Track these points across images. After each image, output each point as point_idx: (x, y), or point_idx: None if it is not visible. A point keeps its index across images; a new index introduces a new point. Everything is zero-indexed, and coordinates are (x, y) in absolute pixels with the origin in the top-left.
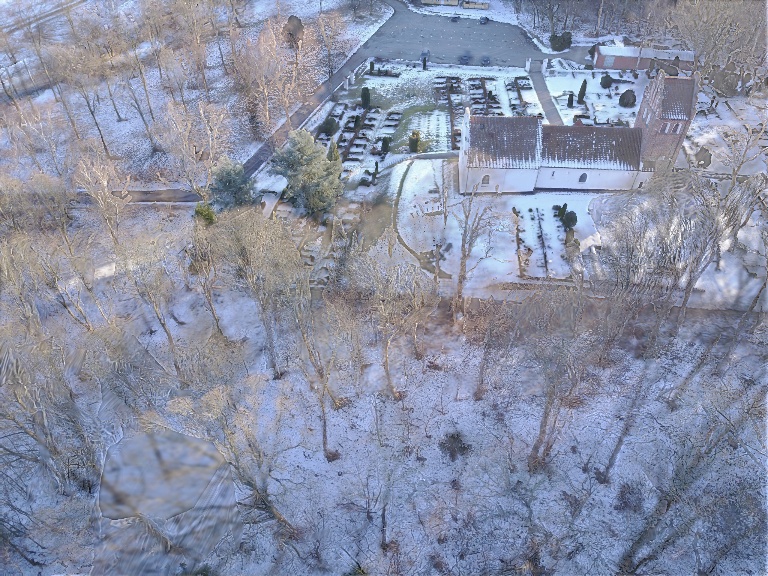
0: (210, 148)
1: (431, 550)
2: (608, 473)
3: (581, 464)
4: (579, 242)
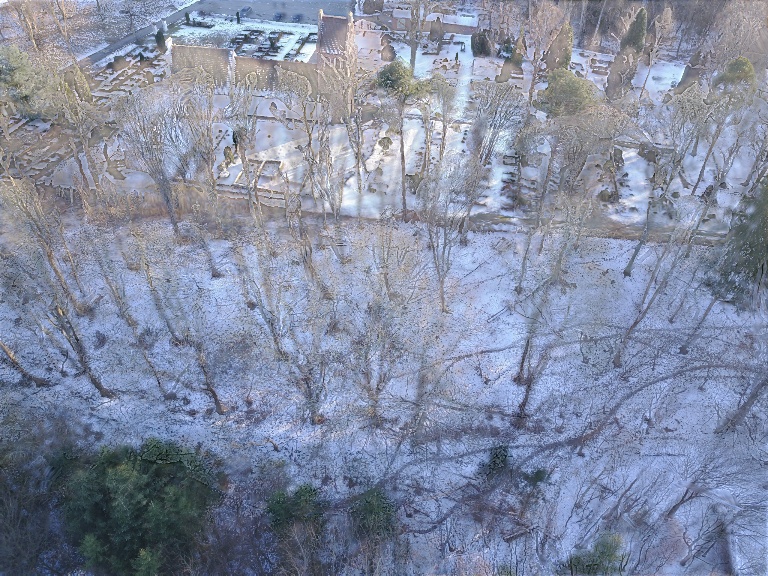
0: None
1: None
2: None
3: None
4: (232, 154)
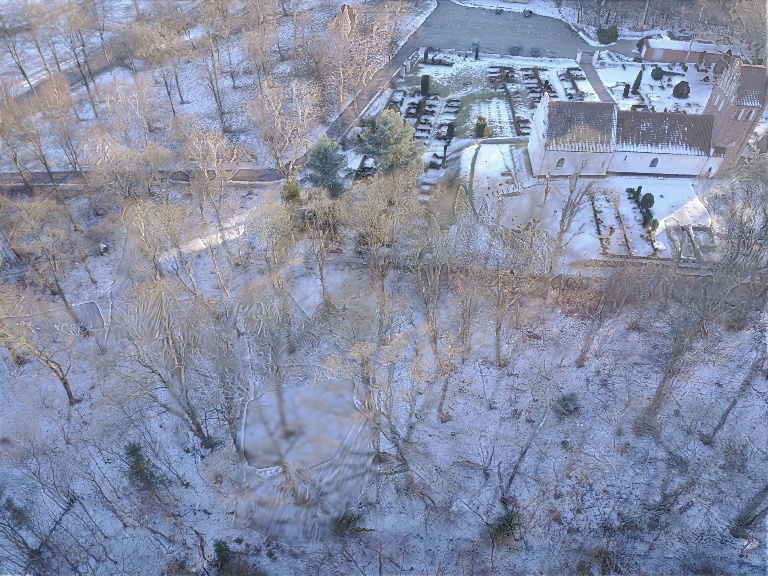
0: (299, 127)
1: (548, 504)
2: (715, 433)
3: (684, 426)
4: (658, 222)
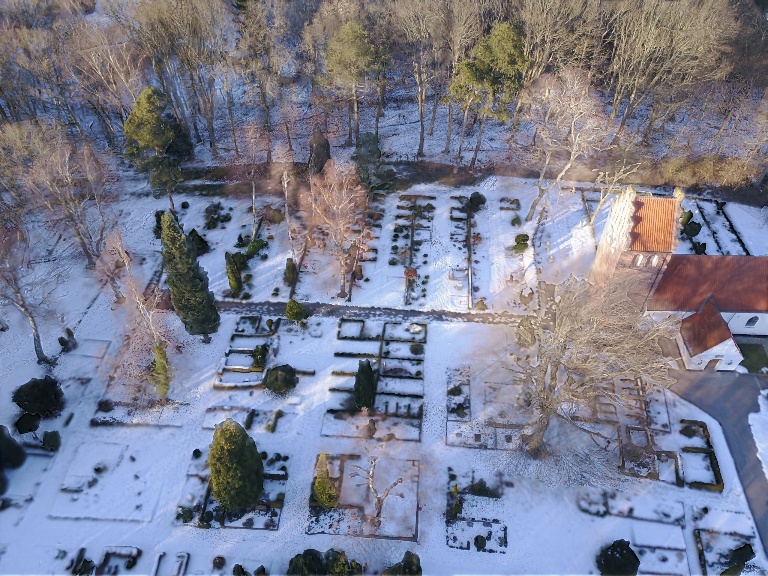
0: None
1: None
2: None
3: None
4: None
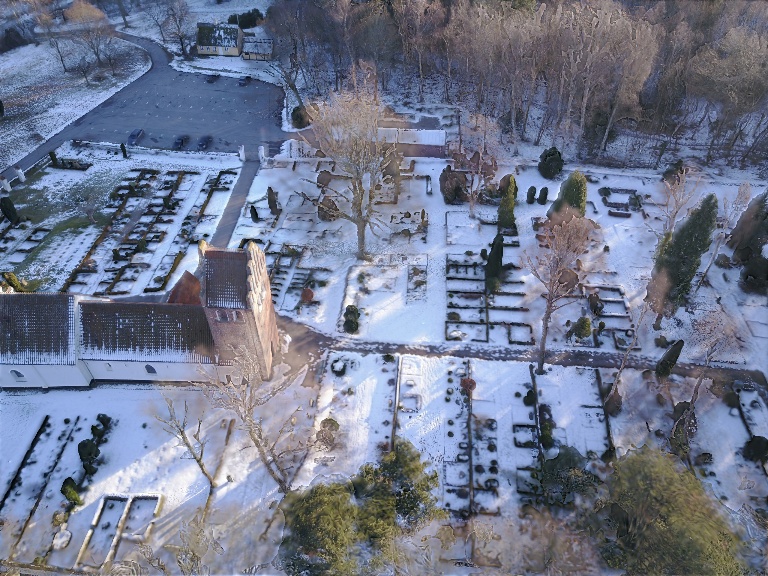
0: None
1: None
2: None
3: None
4: (74, 496)
